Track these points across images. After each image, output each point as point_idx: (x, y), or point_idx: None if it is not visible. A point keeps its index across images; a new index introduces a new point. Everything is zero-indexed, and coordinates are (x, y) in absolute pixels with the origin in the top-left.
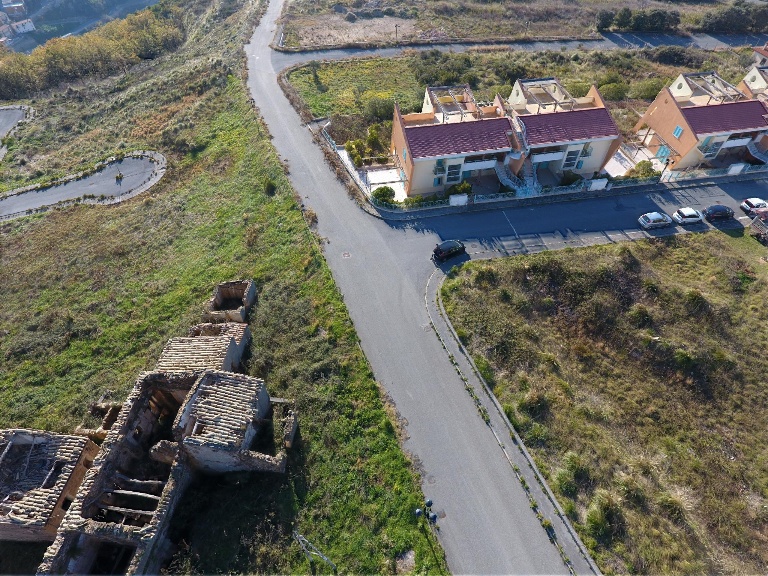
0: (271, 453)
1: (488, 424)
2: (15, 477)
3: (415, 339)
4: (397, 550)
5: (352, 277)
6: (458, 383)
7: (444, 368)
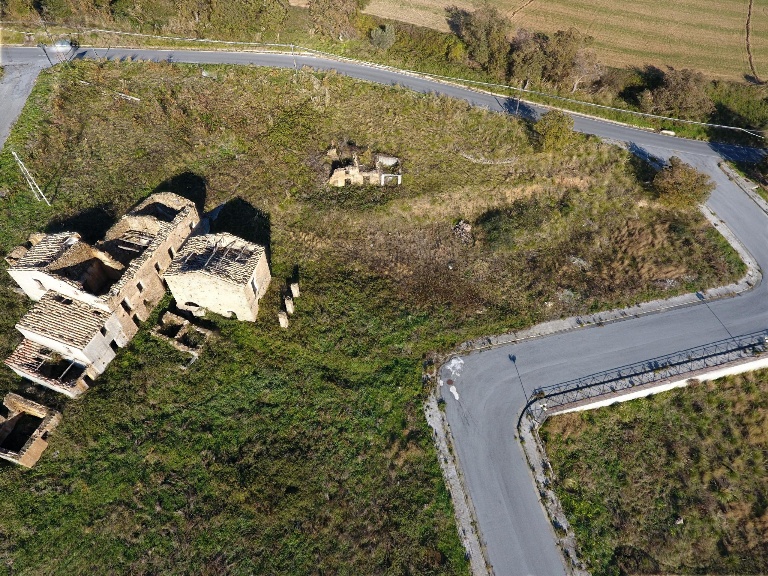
0: None
1: None
2: None
3: None
4: None
5: None
6: None
7: None
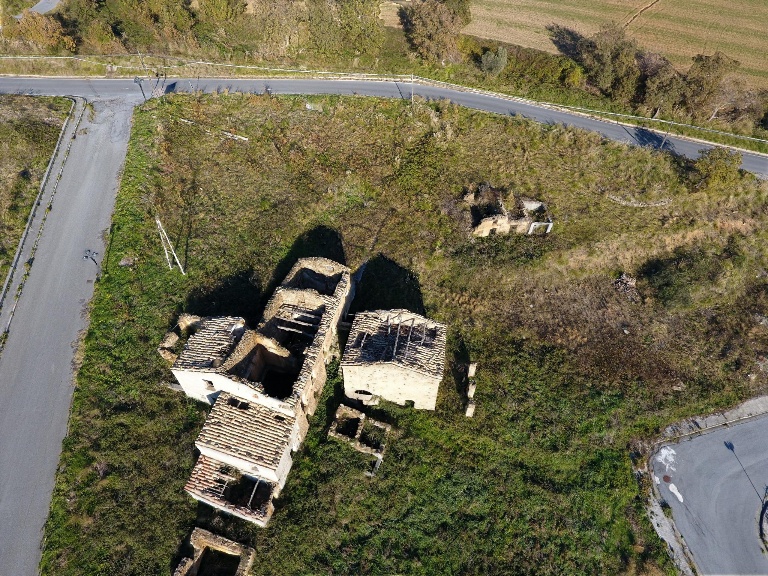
0: (191, 332)
1: (8, 331)
2: (393, 347)
3: (2, 433)
4: (129, 267)
5: (9, 571)
6: (1, 372)
7: (0, 391)
